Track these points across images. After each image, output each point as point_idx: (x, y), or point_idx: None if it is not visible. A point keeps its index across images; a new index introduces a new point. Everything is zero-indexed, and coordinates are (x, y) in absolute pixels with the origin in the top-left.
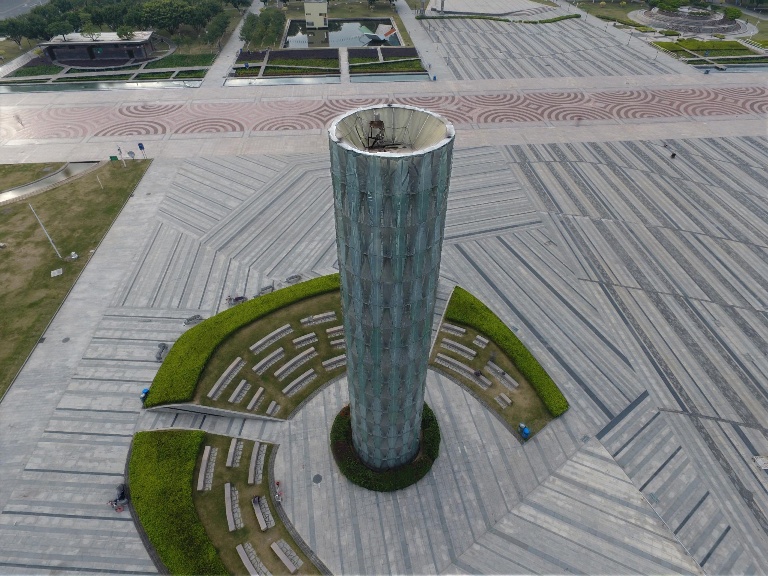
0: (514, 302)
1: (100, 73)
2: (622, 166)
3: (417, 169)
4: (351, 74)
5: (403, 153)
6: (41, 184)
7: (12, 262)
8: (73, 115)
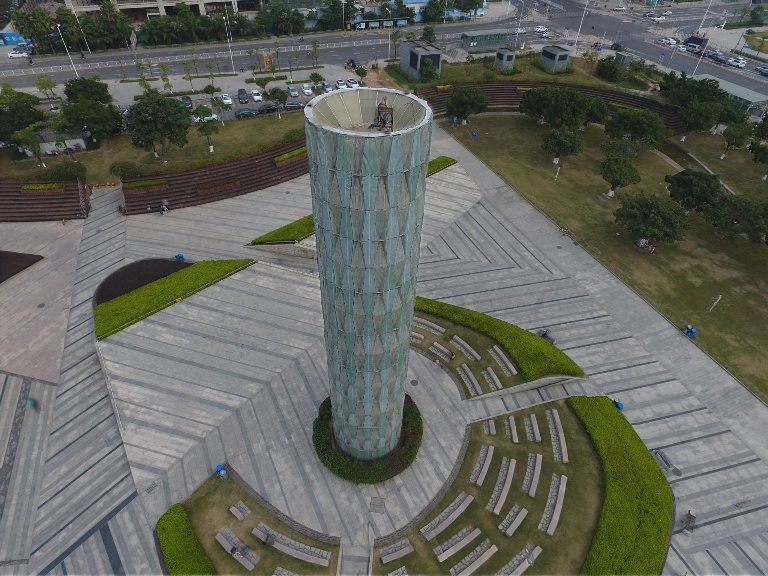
0: None
1: None
2: None
3: None
4: None
5: (346, 90)
6: None
7: None
8: None
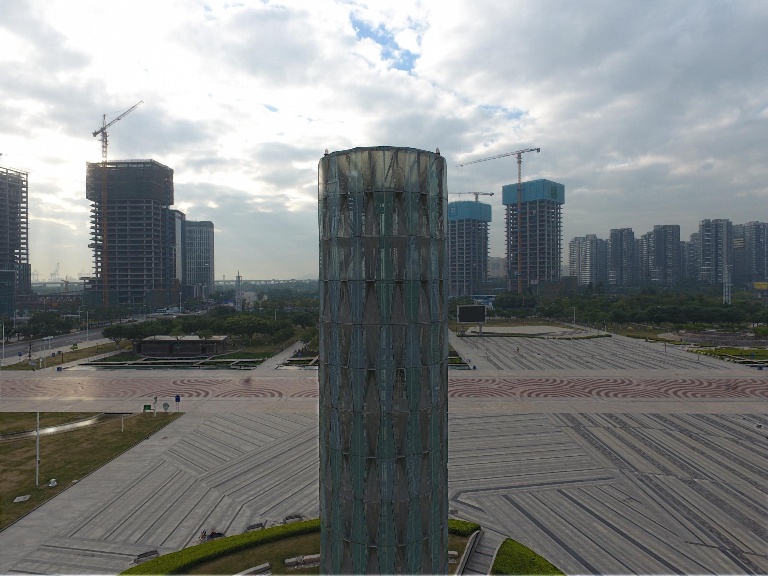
0: (596, 565)
1: (172, 361)
2: (699, 433)
3: (401, 167)
4: None
5: None
6: (66, 427)
7: None
8: (131, 383)
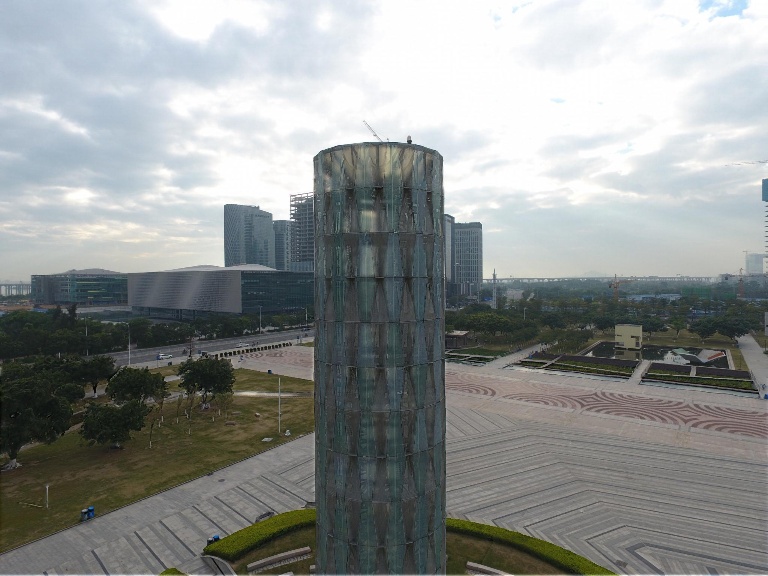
0: None
1: None
2: None
3: None
4: (643, 379)
5: None
6: None
7: (252, 425)
8: None
